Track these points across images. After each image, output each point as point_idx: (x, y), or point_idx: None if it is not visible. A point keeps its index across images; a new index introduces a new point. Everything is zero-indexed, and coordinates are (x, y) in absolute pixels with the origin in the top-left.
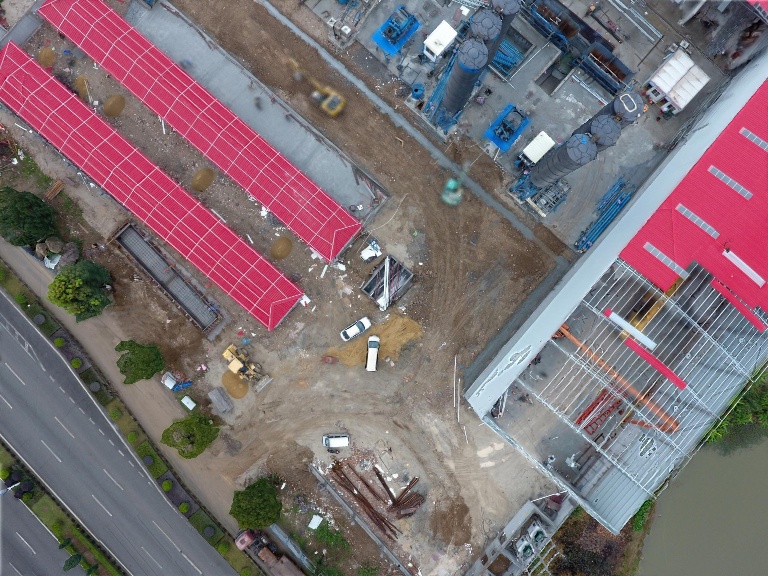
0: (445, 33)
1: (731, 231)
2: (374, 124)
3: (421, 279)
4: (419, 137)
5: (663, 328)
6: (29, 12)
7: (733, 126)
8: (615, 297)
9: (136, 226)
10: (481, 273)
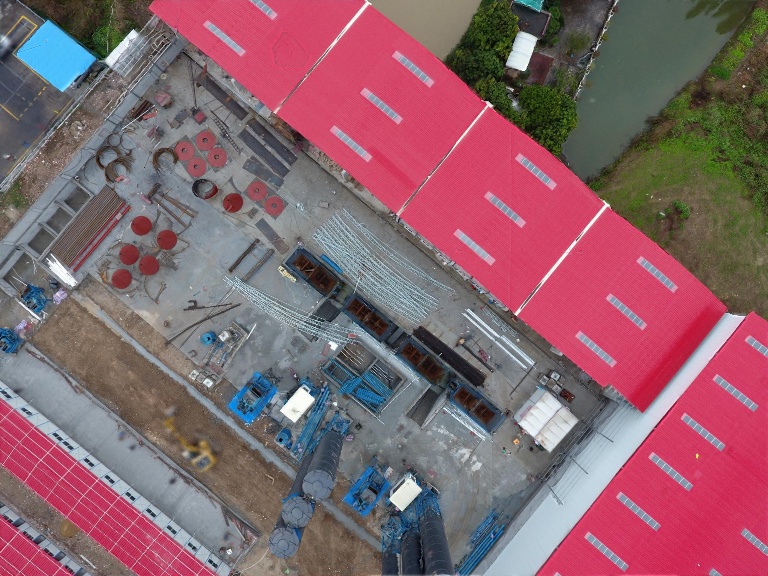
0: (302, 400)
1: None
2: (244, 462)
3: None
4: (290, 473)
5: None
6: None
7: (579, 530)
8: None
9: None
10: None
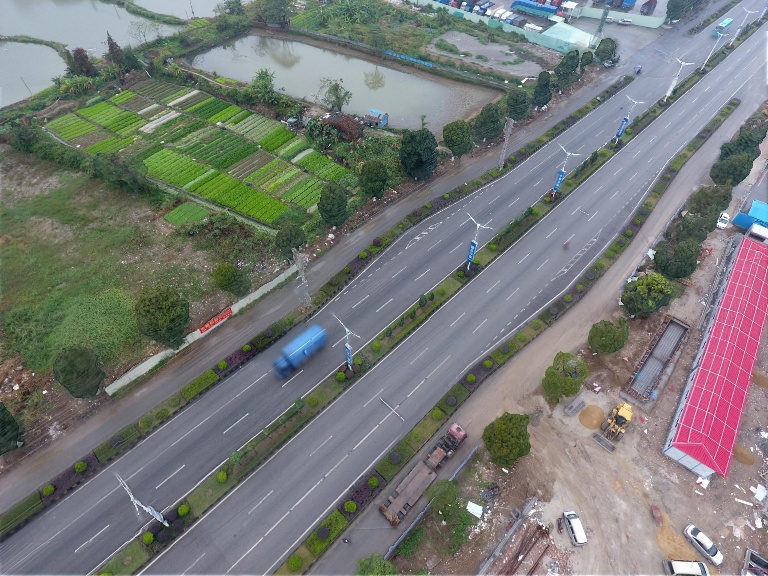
0: None
1: None
2: None
3: None
4: None
5: None
6: None
7: None
8: None
9: (688, 333)
10: None
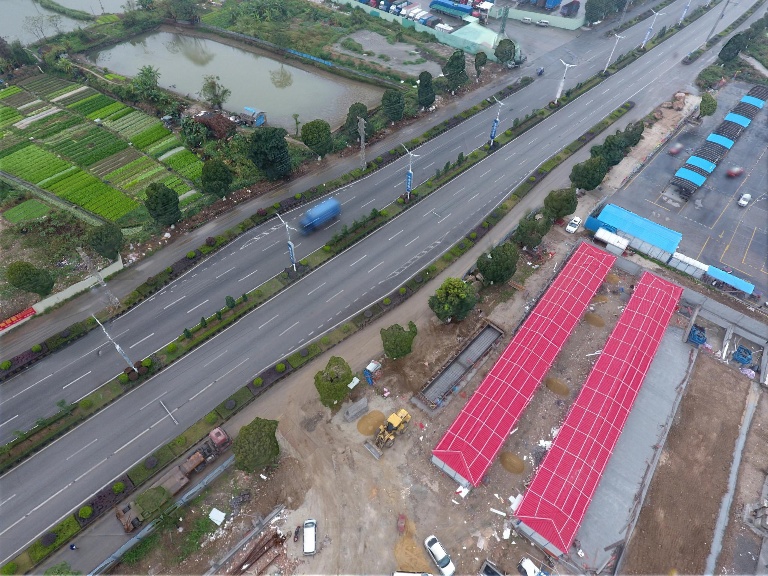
0: None
1: None
2: (681, 567)
3: None
4: None
5: None
6: (642, 267)
7: None
8: None
9: (502, 338)
10: None
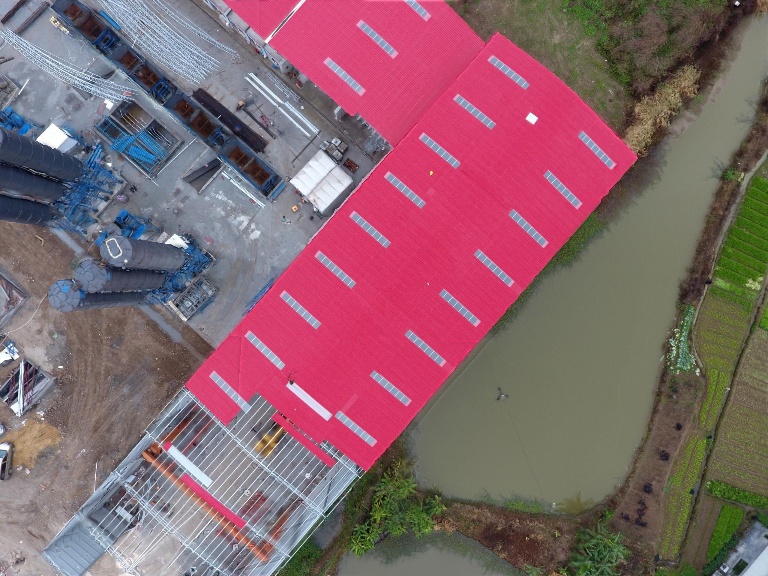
0: (54, 137)
1: (297, 362)
2: None
3: (60, 383)
4: (61, 235)
5: (220, 464)
6: None
7: (309, 249)
8: (176, 429)
9: None
10: (124, 377)
